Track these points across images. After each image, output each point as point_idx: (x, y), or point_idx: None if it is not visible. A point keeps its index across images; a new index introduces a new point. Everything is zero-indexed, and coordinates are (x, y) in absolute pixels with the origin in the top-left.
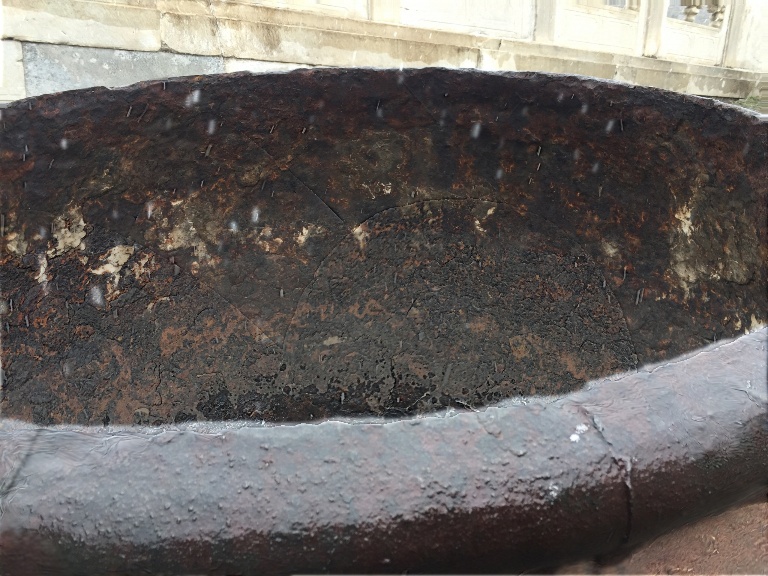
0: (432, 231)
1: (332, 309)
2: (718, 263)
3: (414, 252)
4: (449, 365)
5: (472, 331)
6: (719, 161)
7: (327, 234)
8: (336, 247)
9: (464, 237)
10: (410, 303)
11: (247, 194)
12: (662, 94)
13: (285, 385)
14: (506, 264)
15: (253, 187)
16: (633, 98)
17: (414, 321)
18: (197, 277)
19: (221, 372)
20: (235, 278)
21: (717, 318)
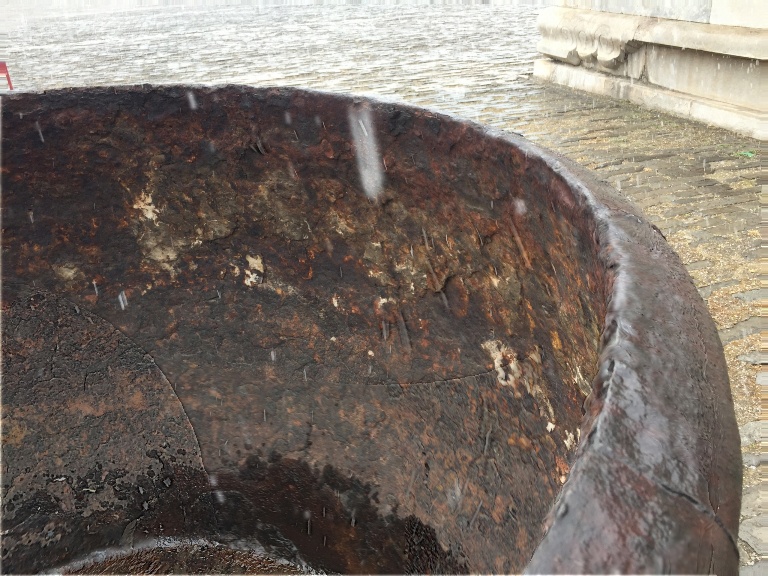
0: None
1: None
2: (196, 230)
3: None
4: None
5: None
6: (173, 138)
7: None
8: None
9: None
10: None
11: None
12: (85, 91)
13: None
14: None
15: None
16: (48, 104)
17: None
18: None
19: None
20: None
21: (212, 277)
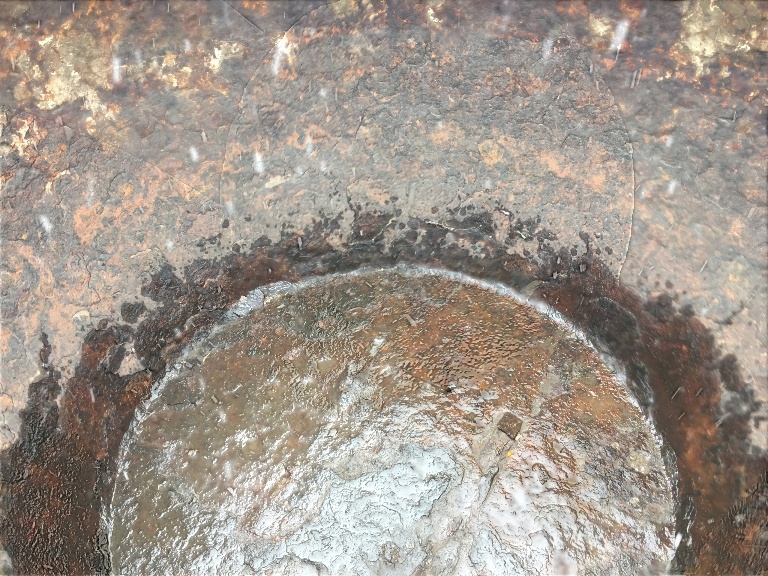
0: (375, 29)
1: (267, 145)
2: (751, 32)
3: (355, 59)
4: (412, 185)
5: (434, 143)
6: None
7: (245, 52)
8: (259, 67)
9: (415, 32)
10: (357, 122)
11: (135, 13)
12: None
13: (233, 243)
14: (469, 59)
15: (141, 2)
16: None
17: (365, 142)
18: (96, 137)
19: (157, 246)
20: (143, 129)
21: (739, 94)
